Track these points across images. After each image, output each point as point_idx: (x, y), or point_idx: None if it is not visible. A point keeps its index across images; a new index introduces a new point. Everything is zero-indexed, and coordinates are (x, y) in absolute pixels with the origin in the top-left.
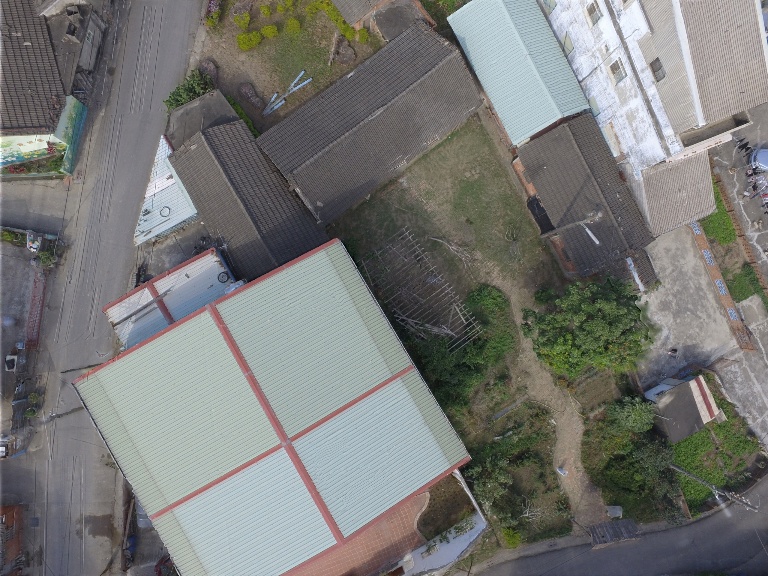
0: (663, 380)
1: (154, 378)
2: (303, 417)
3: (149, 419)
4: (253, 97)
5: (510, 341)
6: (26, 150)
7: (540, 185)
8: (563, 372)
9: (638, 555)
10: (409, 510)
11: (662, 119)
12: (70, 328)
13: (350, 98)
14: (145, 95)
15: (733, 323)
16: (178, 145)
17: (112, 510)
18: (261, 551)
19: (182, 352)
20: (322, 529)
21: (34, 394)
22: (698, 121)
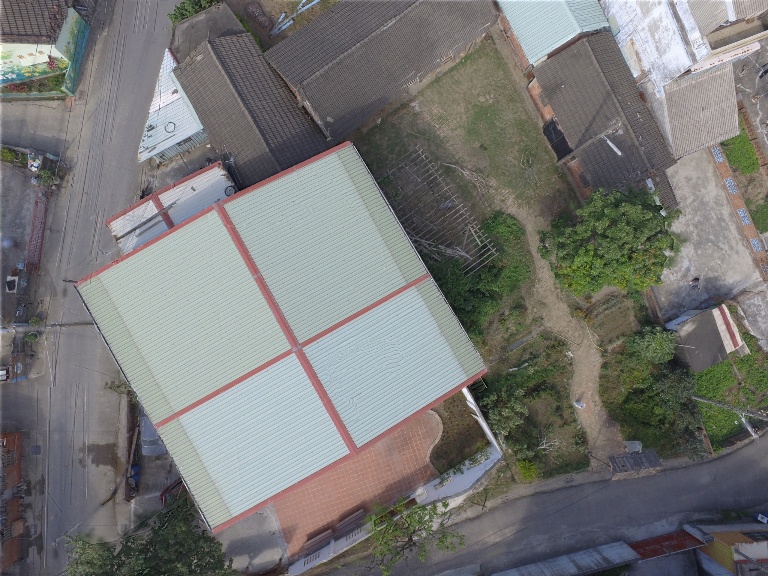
0: (684, 312)
1: (159, 281)
2: (314, 323)
3: (154, 323)
4: (260, 16)
5: (525, 271)
6: (27, 63)
7: (557, 105)
8: (580, 303)
9: (658, 492)
10: (421, 443)
11: (688, 22)
12: (72, 252)
13: (361, 11)
14: (149, 14)
15: (756, 254)
16: (183, 59)
17: (116, 439)
18: (271, 461)
19: (188, 254)
20: (334, 438)
21: (36, 318)
22: (728, 15)
